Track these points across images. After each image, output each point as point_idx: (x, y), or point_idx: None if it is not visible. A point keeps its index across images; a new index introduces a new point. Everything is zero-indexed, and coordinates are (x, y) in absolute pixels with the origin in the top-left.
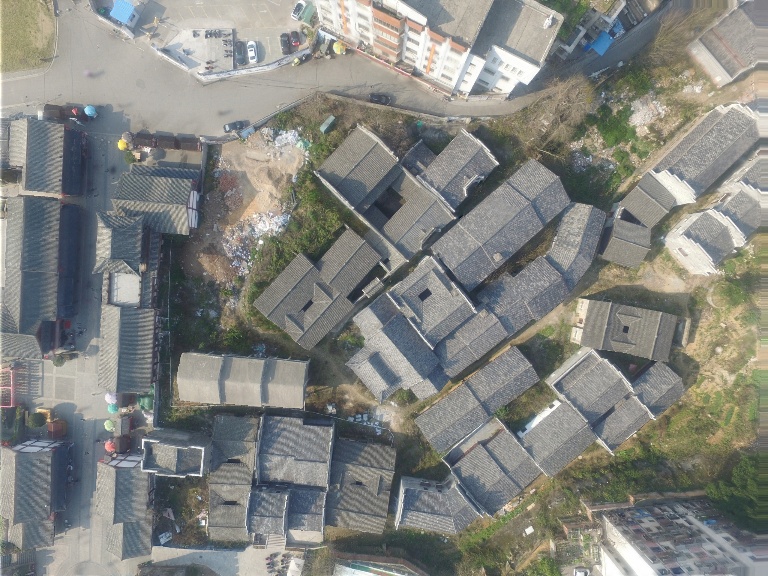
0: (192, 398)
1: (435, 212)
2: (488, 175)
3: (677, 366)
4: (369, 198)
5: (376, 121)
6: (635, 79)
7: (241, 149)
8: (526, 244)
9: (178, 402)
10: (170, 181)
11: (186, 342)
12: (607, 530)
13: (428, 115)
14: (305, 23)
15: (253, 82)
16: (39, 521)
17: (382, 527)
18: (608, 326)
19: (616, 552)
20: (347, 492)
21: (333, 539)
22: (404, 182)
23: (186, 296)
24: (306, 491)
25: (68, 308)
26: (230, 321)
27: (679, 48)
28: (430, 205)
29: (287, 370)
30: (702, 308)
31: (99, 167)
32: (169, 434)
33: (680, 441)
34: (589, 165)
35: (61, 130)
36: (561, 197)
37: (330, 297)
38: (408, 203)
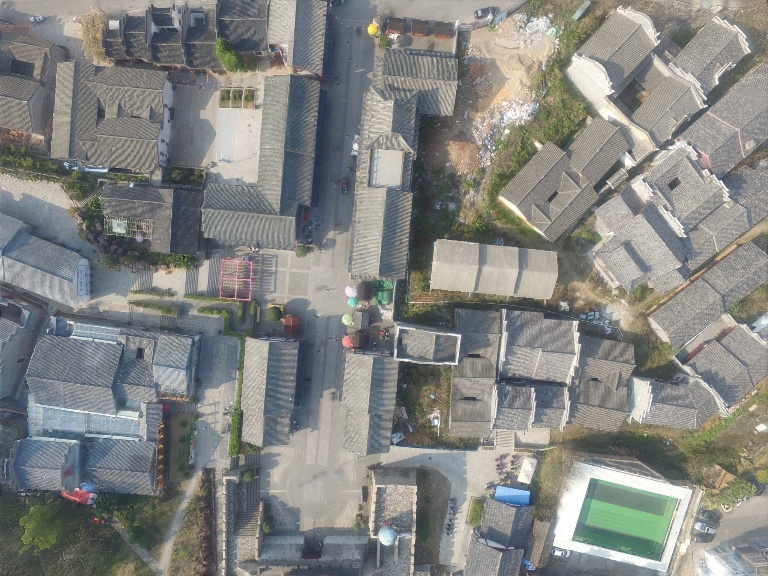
0: (446, 286)
1: (686, 100)
2: None
3: None
4: (619, 86)
5: (641, 2)
6: None
7: (490, 36)
8: None
9: (414, 297)
10: (435, 60)
11: (427, 234)
12: None
13: (681, 2)
14: None
15: None
16: (277, 417)
17: (619, 424)
18: None
19: None
20: (585, 388)
21: (559, 441)
22: (649, 72)
23: (426, 188)
24: (546, 386)
25: (314, 196)
26: (470, 214)
27: None
28: (683, 92)
29: (539, 258)
30: None
31: (343, 54)
32: (415, 326)
33: None
34: None
35: (324, 7)
36: None
37: (578, 186)
38: (657, 92)
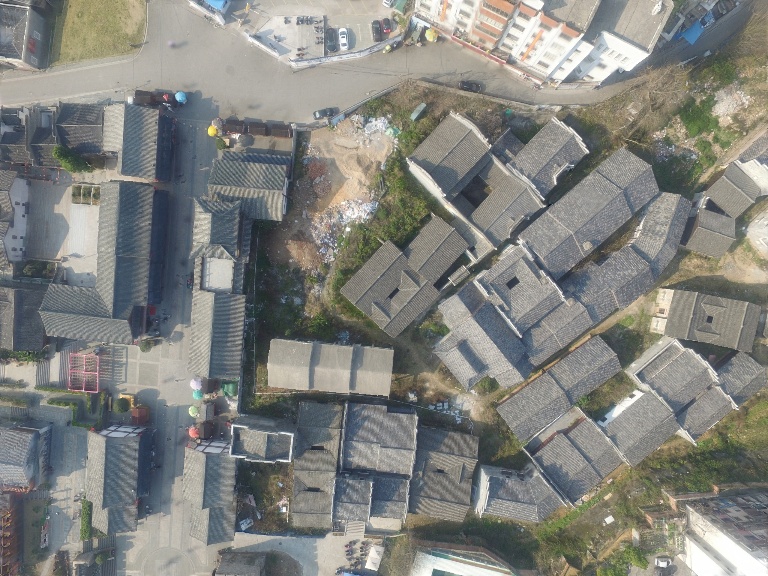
0: (281, 384)
1: (524, 200)
2: (577, 163)
3: (756, 357)
4: (458, 186)
5: (471, 108)
6: (720, 69)
7: (330, 136)
8: (614, 233)
9: (261, 389)
10: (264, 167)
11: (271, 329)
12: (691, 519)
13: (519, 103)
14: (397, 10)
15: (347, 68)
16: (124, 506)
17: (464, 515)
18: (693, 316)
19: (703, 541)
20: (429, 480)
21: (411, 527)
22: (491, 170)
23: (271, 283)
24: (389, 478)
25: (156, 294)
26: (315, 308)
27: (766, 38)
28: (520, 193)
29: (375, 357)
30: None
31: (187, 153)
32: (255, 420)
33: (759, 432)
34: (671, 155)
35: (156, 115)
36: (651, 186)
37: (417, 285)
38: (497, 191)
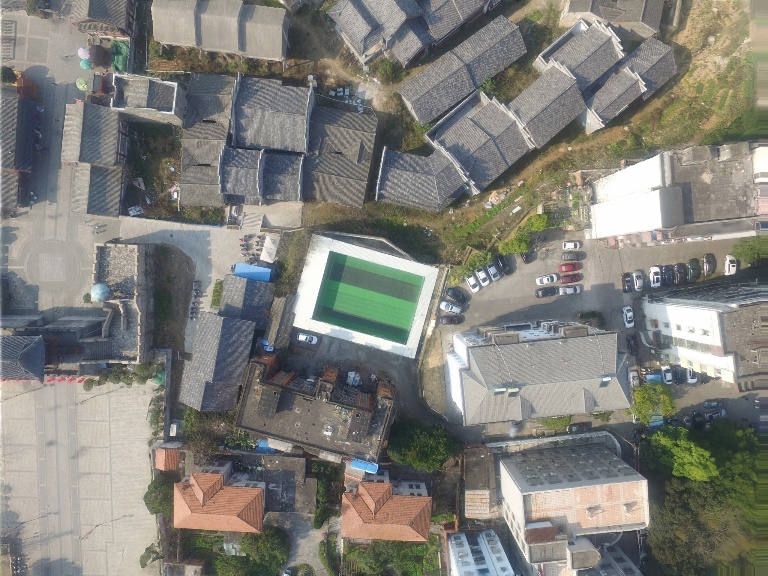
0: (167, 37)
1: None
2: None
3: None
4: None
5: None
6: None
7: None
8: None
9: (153, 65)
10: None
11: None
12: (597, 192)
13: None
14: None
15: None
16: (3, 177)
17: (362, 198)
18: None
19: None
20: (326, 159)
21: (311, 225)
22: None
23: None
24: (283, 155)
25: None
26: None
27: None
28: None
29: (266, 13)
30: None
31: None
32: None
33: (673, 129)
34: None
35: None
36: None
37: None
38: None
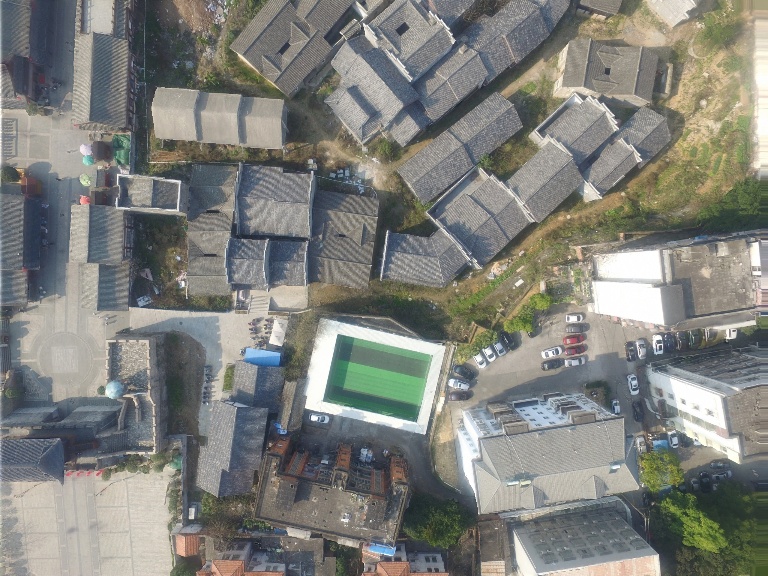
0: (168, 134)
1: None
2: None
3: None
4: None
5: None
6: None
7: None
8: None
9: (155, 157)
10: None
11: None
12: (598, 266)
13: None
14: None
15: None
16: (12, 277)
17: (367, 279)
18: (589, 63)
19: (607, 279)
20: (330, 243)
21: (318, 305)
22: None
23: (162, 47)
24: (288, 242)
25: (42, 53)
26: None
27: None
28: None
29: (265, 105)
30: (684, 61)
31: None
32: None
33: (669, 194)
34: None
35: None
36: None
37: (307, 36)
38: None
